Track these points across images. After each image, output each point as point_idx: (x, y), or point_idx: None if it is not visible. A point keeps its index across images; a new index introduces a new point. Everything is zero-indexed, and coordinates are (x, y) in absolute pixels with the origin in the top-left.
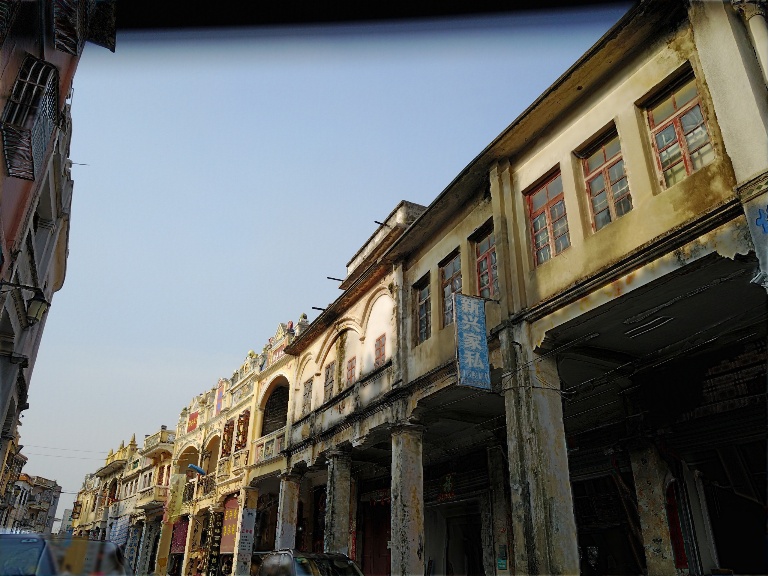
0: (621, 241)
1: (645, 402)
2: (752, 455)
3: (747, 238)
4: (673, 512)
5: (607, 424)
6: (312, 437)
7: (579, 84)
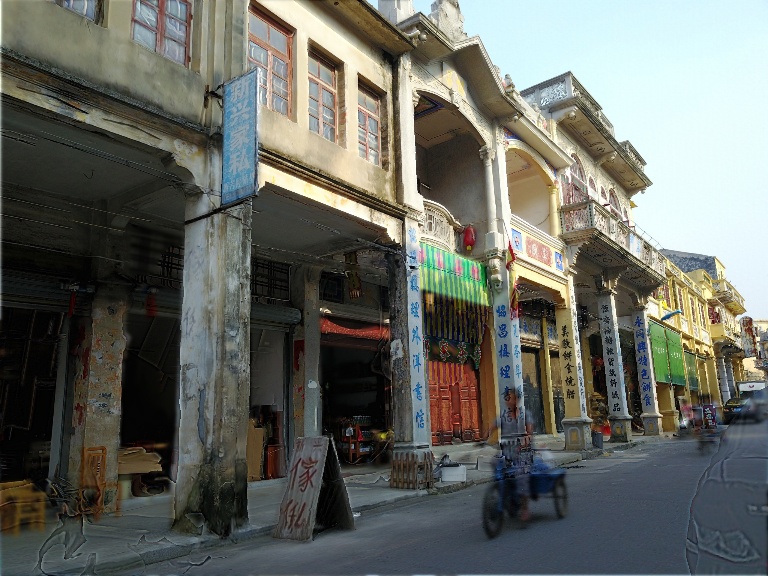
0: (336, 164)
1: None
2: None
3: None
4: None
5: (50, 249)
6: None
7: (341, 3)
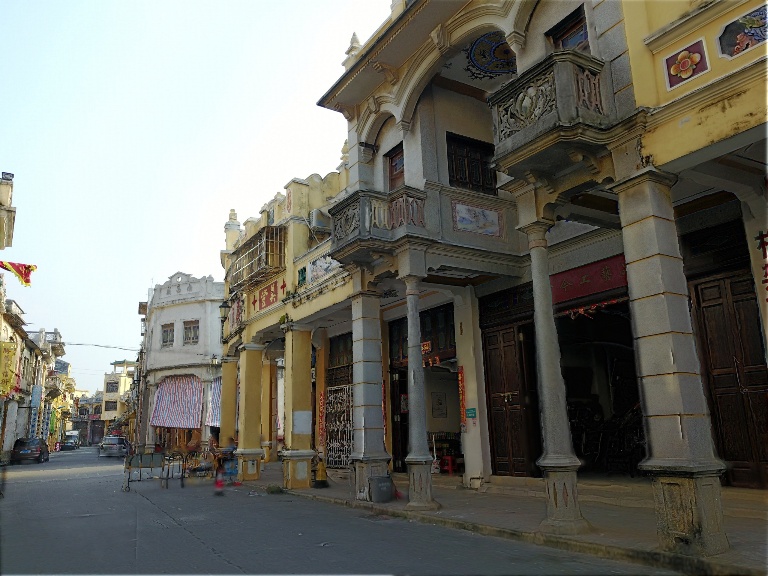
0: None
1: None
2: None
3: None
4: None
5: None
6: None
7: None
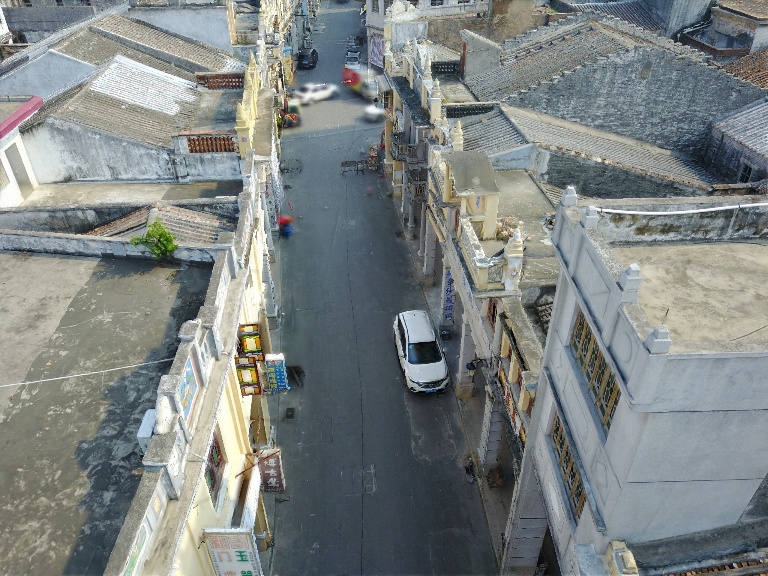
0: None
1: None
2: None
3: None
4: None
5: None
6: (287, 25)
7: None
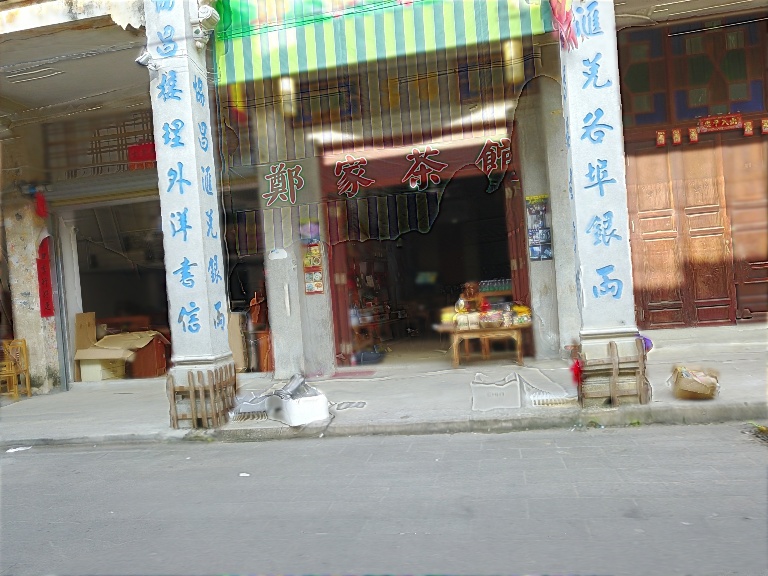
0: None
1: (25, 156)
2: (124, 216)
3: (141, 11)
4: (45, 266)
5: None
6: None
7: None
